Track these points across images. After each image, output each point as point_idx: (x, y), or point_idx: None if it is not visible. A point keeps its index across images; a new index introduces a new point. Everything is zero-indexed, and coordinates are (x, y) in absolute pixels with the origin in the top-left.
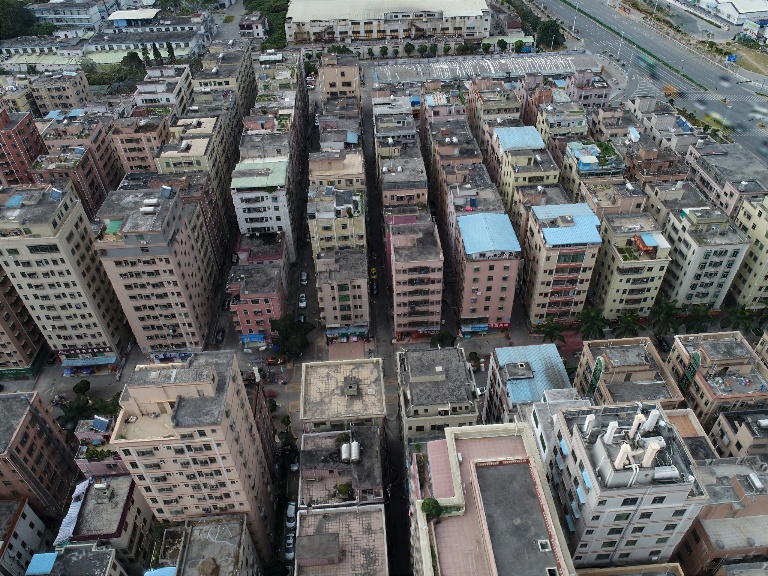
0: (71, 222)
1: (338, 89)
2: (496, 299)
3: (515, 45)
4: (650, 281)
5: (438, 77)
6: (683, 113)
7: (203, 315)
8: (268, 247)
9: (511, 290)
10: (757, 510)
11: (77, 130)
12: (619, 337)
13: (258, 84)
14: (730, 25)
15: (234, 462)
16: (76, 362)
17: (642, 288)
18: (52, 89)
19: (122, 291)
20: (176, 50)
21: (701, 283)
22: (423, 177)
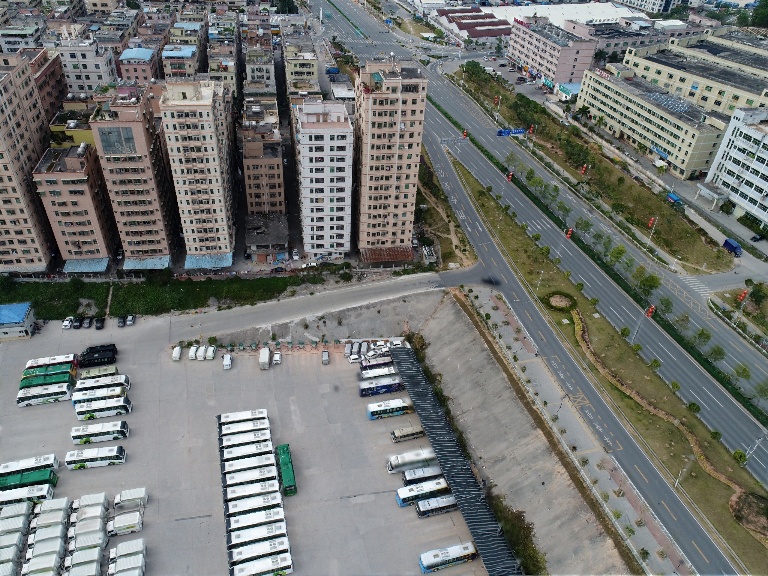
0: None
1: (99, 8)
2: None
3: None
4: None
5: None
6: (336, 44)
7: None
8: None
9: None
10: (158, 95)
11: None
12: None
13: (42, 0)
14: None
15: None
16: None
17: None
18: None
19: None
20: None
21: None
22: (118, 37)
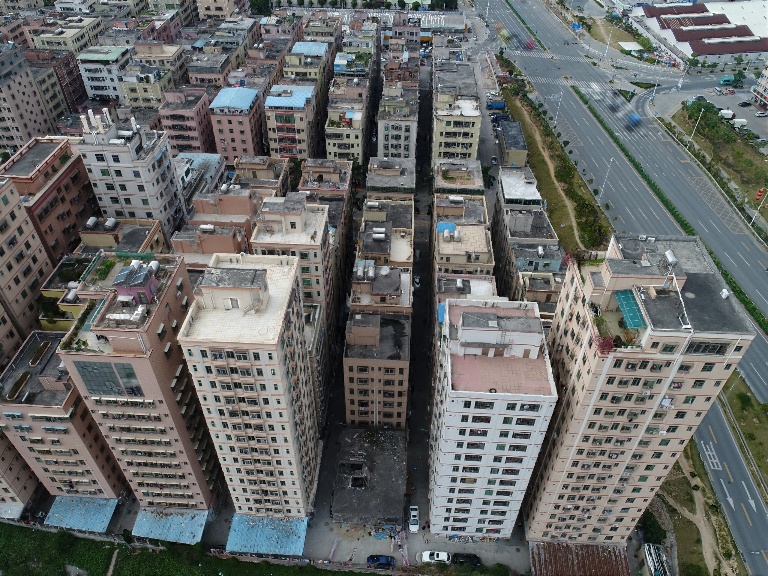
0: None
1: (212, 12)
2: (240, 150)
3: (412, 5)
4: (352, 147)
5: None
6: (504, 62)
7: None
8: (101, 106)
9: (250, 143)
10: (231, 210)
11: None
12: None
13: (149, 2)
14: (614, 6)
15: None
16: None
17: (347, 153)
18: None
19: None
20: None
21: (391, 154)
22: (218, 65)
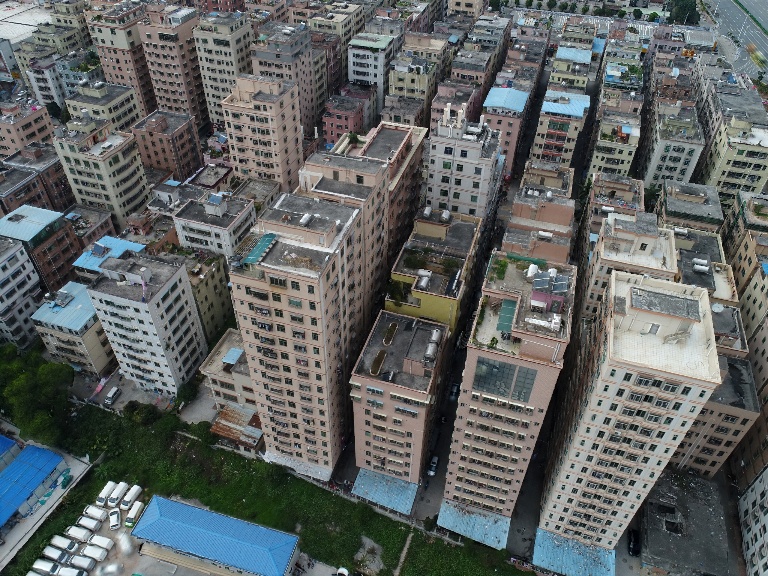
0: (242, 33)
1: (462, 8)
2: None
3: (649, 16)
4: (621, 163)
5: (561, 25)
6: (765, 88)
7: (306, 124)
8: (362, 91)
9: (513, 146)
10: (549, 218)
11: (268, 0)
12: (582, 197)
13: None
14: None
15: (279, 138)
16: (222, 134)
17: (614, 168)
18: None
19: None
20: None
21: (663, 175)
22: (484, 63)
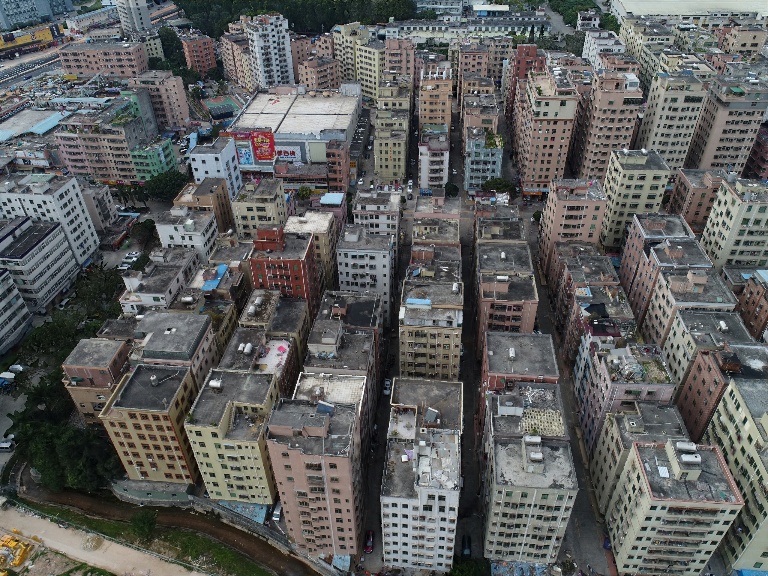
0: None
1: (746, 48)
2: None
3: None
4: None
5: None
6: None
7: None
8: None
9: None
10: None
11: None
12: None
13: (689, 41)
14: None
15: None
16: None
17: None
18: (499, 46)
19: (718, 134)
20: (537, 33)
21: None
22: None
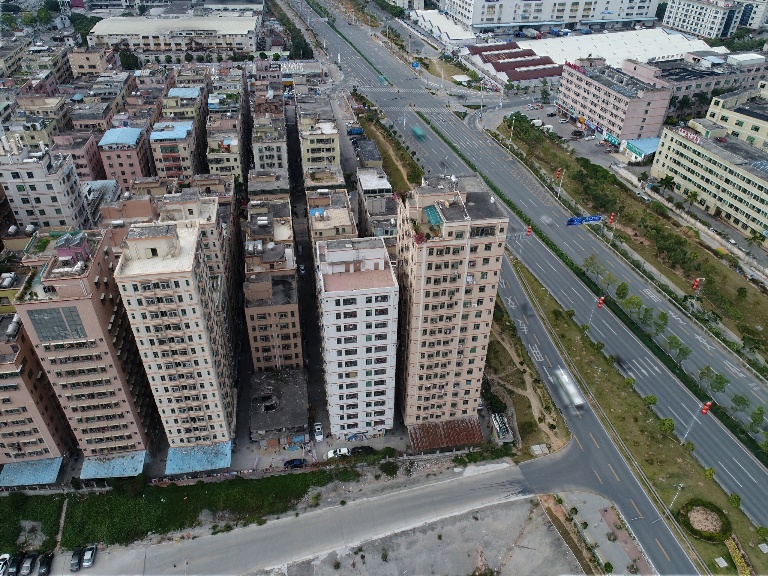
0: None
1: (86, 70)
2: None
3: (273, 57)
4: (232, 169)
5: None
6: (358, 97)
7: None
8: None
9: (139, 174)
10: (134, 213)
11: None
12: None
13: (22, 64)
14: None
15: None
16: None
17: None
18: None
19: None
20: None
21: None
22: (101, 112)
